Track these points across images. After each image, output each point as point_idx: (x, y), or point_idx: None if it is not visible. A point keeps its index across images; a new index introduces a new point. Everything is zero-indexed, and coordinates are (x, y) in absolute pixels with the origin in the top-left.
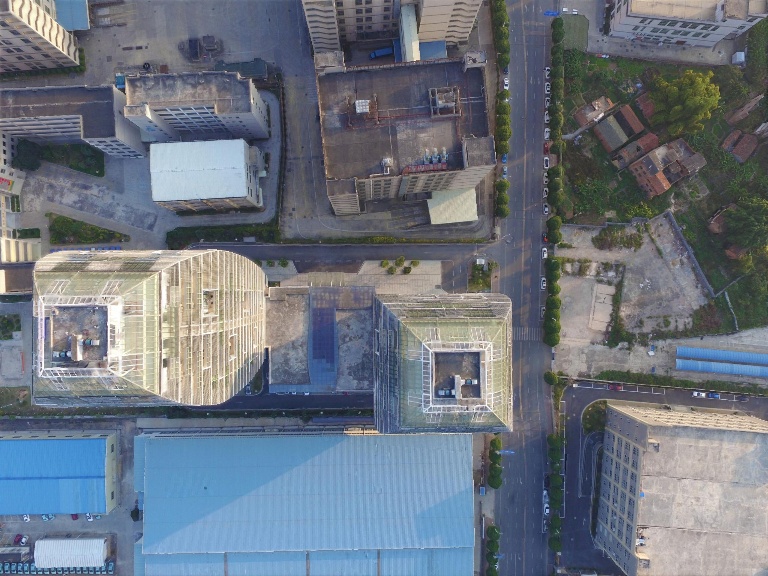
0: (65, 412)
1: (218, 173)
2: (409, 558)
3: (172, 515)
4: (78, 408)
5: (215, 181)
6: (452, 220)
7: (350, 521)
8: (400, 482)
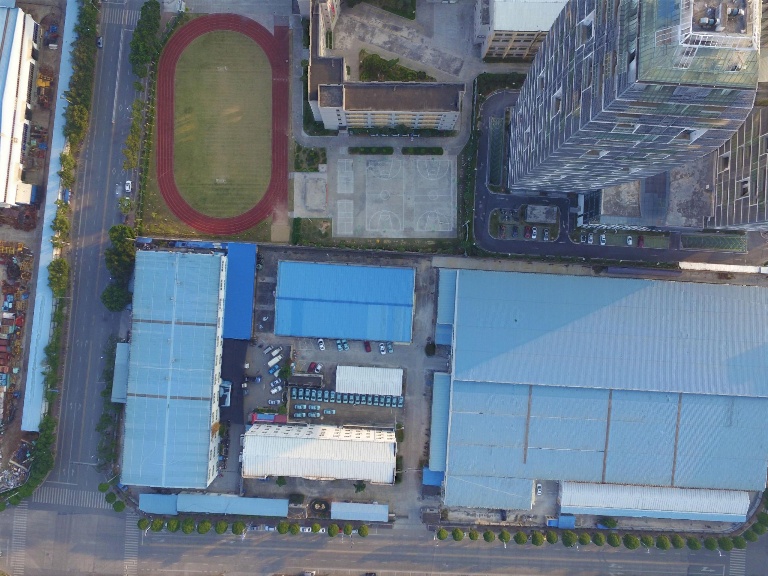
0: (365, 246)
1: (560, 6)
2: (710, 405)
3: (483, 344)
4: (378, 242)
5: (556, 14)
6: (761, 79)
7: (656, 363)
8: (706, 329)
